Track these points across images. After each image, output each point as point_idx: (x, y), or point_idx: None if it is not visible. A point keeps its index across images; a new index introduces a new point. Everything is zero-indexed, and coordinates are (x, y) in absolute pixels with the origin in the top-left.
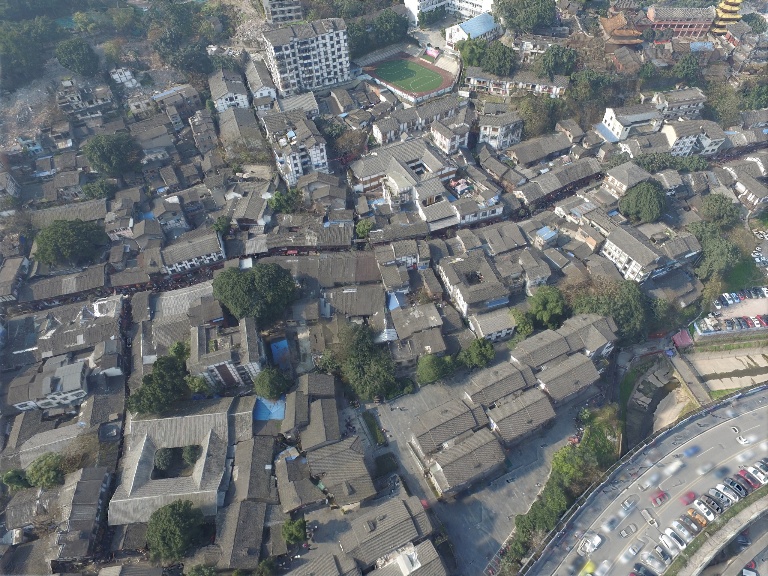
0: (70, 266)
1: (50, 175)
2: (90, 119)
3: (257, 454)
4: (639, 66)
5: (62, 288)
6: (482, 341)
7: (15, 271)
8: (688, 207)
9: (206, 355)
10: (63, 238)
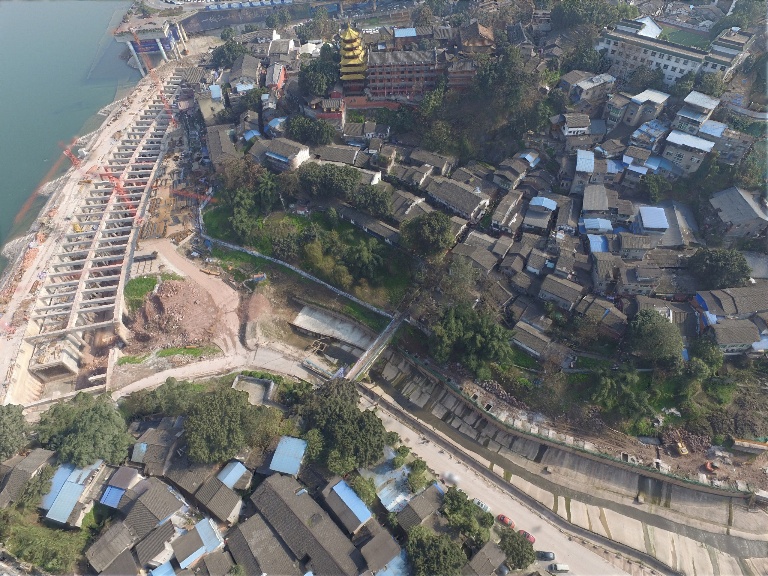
0: None
1: None
2: None
3: None
4: None
5: None
6: None
7: None
8: None
9: None
10: None
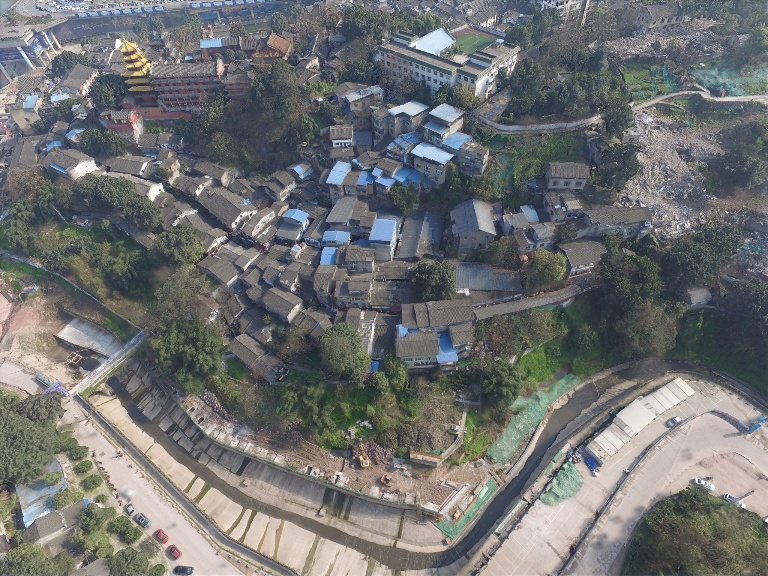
0: None
1: None
2: None
3: None
4: None
5: None
6: None
7: None
8: None
9: None
10: None
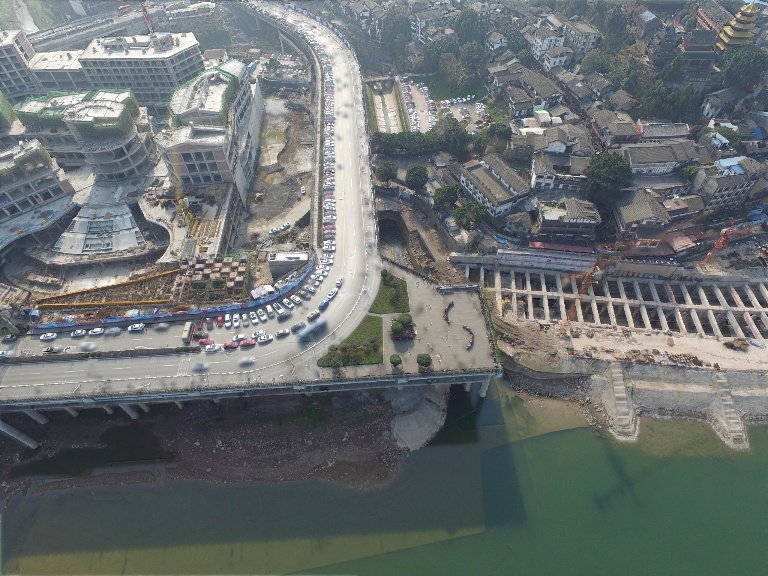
0: None
1: None
2: None
3: None
4: (608, 4)
5: None
6: None
7: None
8: None
9: None
10: None
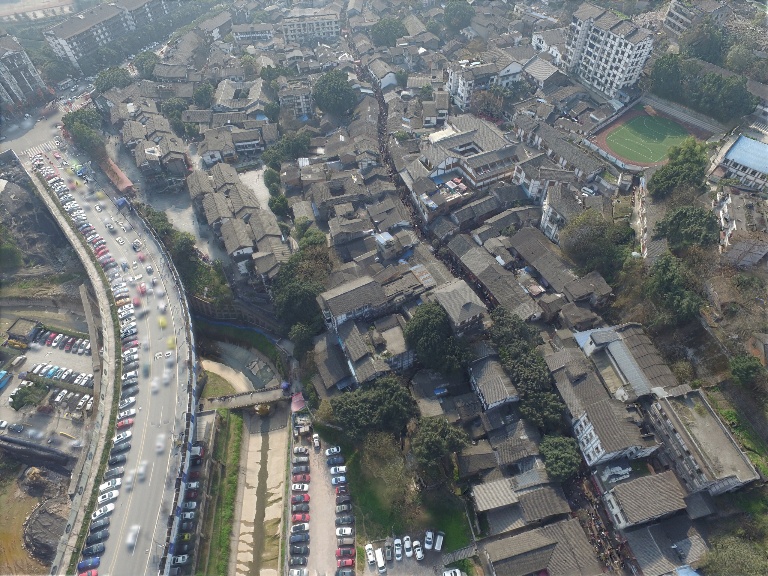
0: (372, 38)
1: (443, 8)
2: (499, 0)
3: (236, 116)
4: (765, 362)
5: (358, 42)
6: (281, 197)
7: (369, 25)
8: (477, 442)
9: (284, 77)
10: (382, 24)
